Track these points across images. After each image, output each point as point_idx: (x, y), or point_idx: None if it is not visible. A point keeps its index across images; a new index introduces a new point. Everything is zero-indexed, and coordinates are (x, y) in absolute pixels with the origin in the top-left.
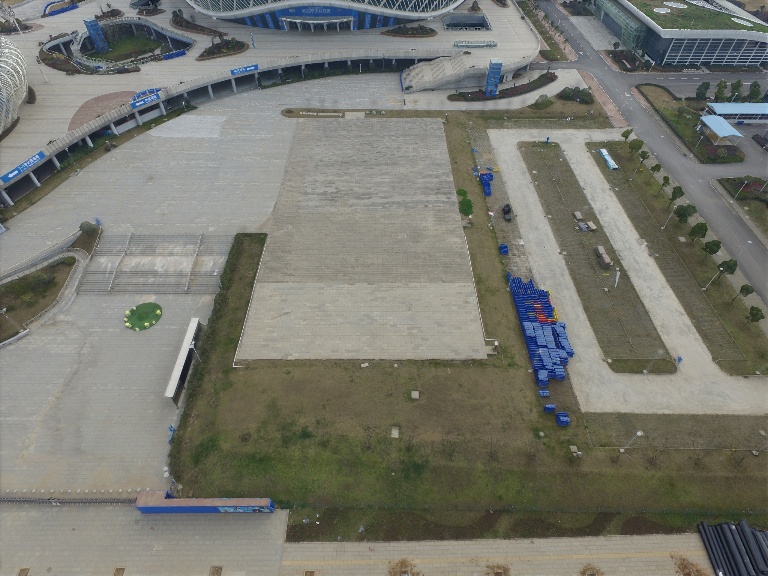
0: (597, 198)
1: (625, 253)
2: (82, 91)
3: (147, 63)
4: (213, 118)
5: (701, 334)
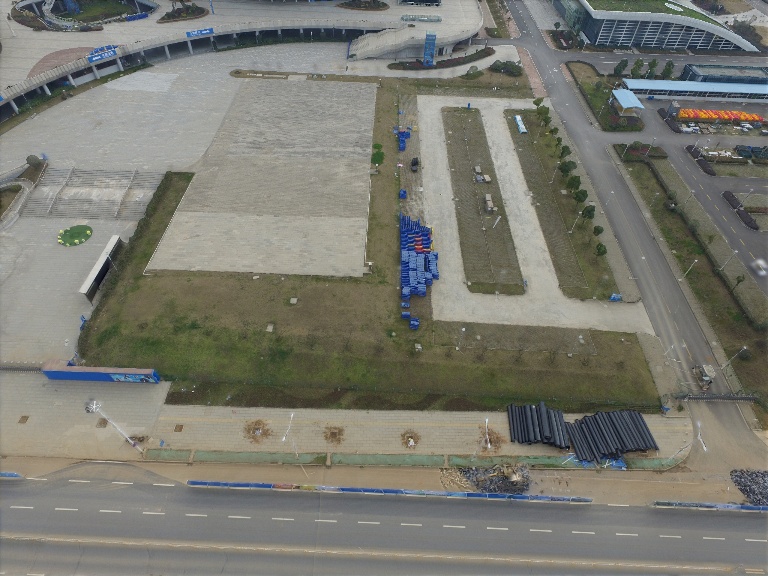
0: (500, 156)
1: (511, 202)
2: (45, 45)
3: (110, 23)
4: (166, 75)
5: (556, 267)
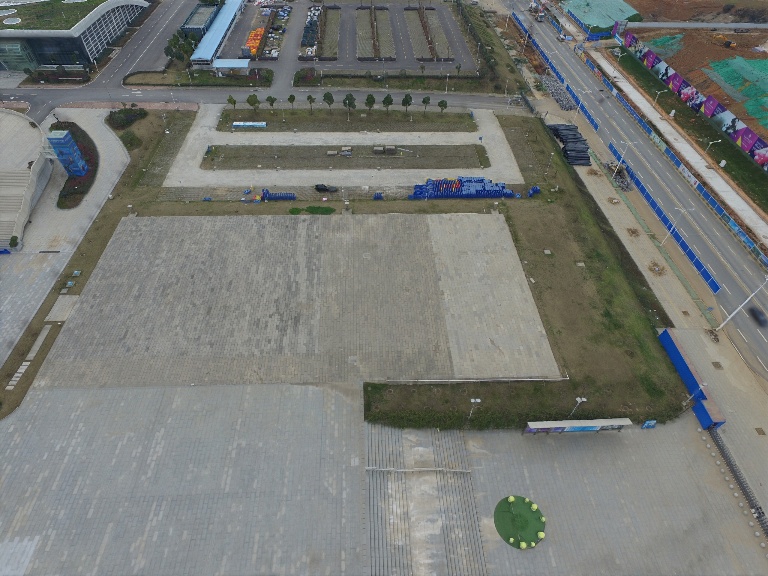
0: (307, 141)
1: (377, 142)
2: None
3: None
4: None
5: (450, 131)
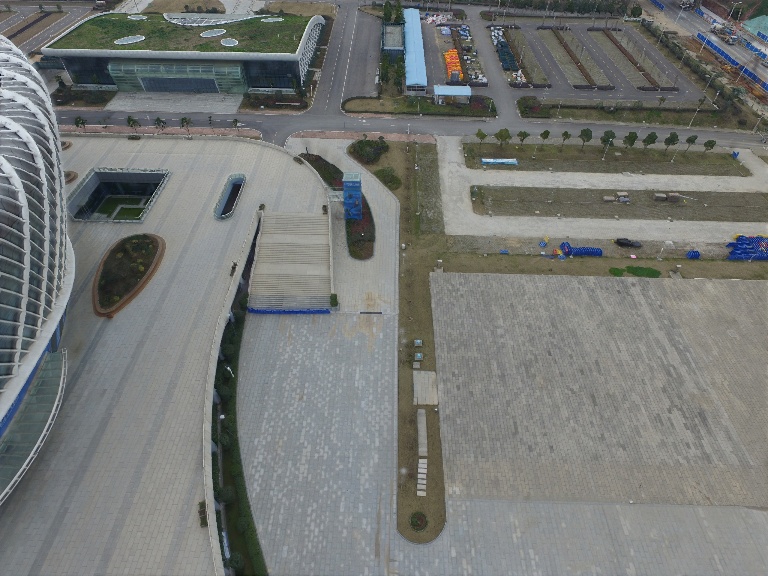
0: (571, 183)
1: (648, 186)
2: None
3: None
4: None
5: (722, 175)
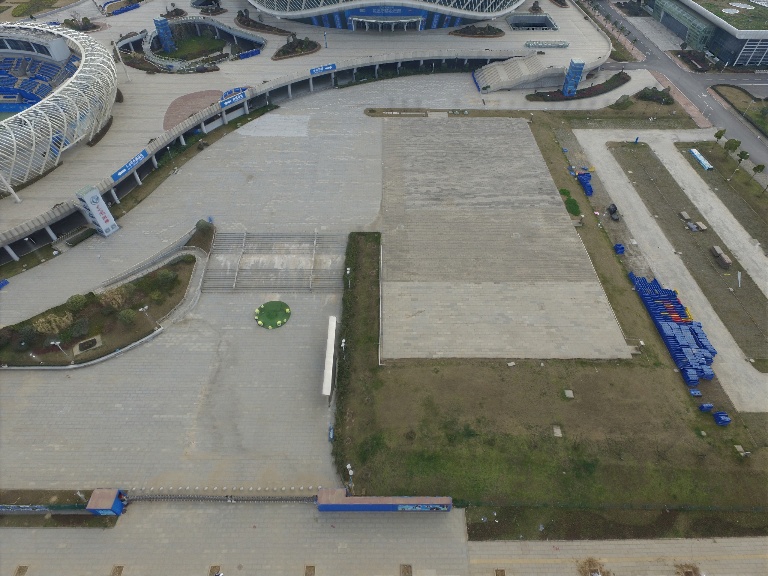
0: (699, 198)
1: (741, 253)
2: (167, 90)
3: (224, 62)
4: (297, 117)
5: None
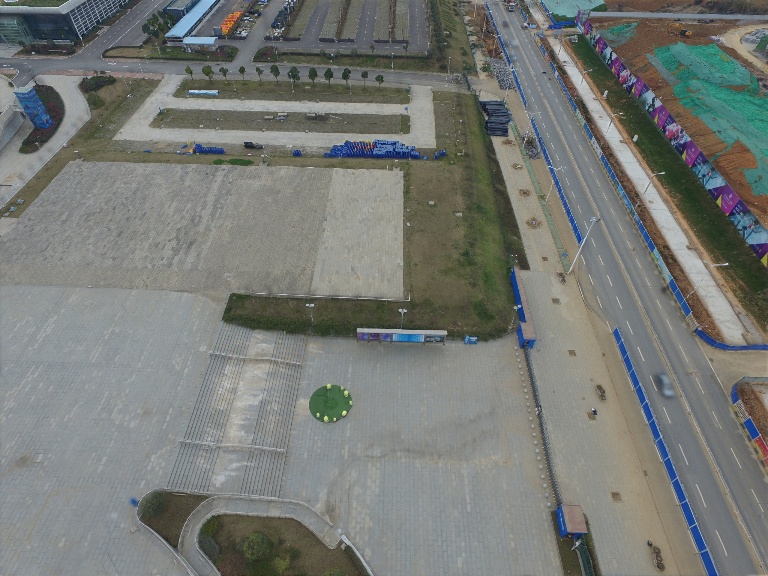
0: (250, 107)
1: (313, 110)
2: None
3: None
4: None
5: (384, 103)
